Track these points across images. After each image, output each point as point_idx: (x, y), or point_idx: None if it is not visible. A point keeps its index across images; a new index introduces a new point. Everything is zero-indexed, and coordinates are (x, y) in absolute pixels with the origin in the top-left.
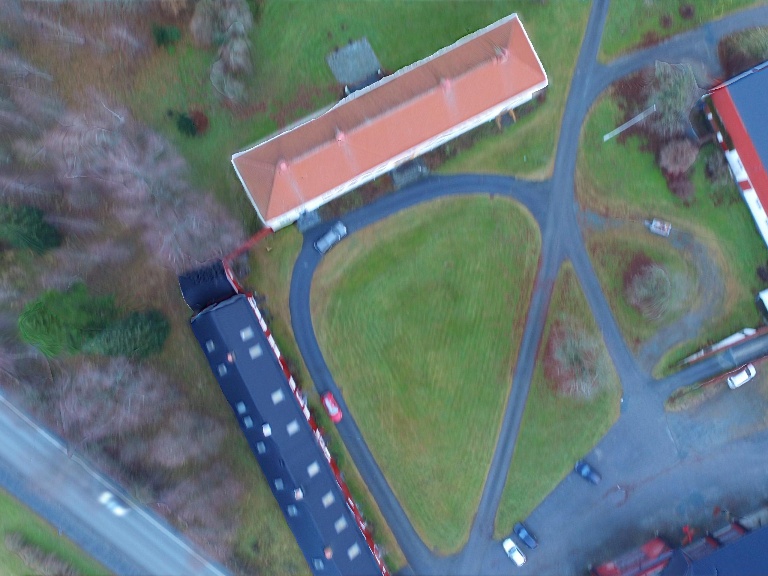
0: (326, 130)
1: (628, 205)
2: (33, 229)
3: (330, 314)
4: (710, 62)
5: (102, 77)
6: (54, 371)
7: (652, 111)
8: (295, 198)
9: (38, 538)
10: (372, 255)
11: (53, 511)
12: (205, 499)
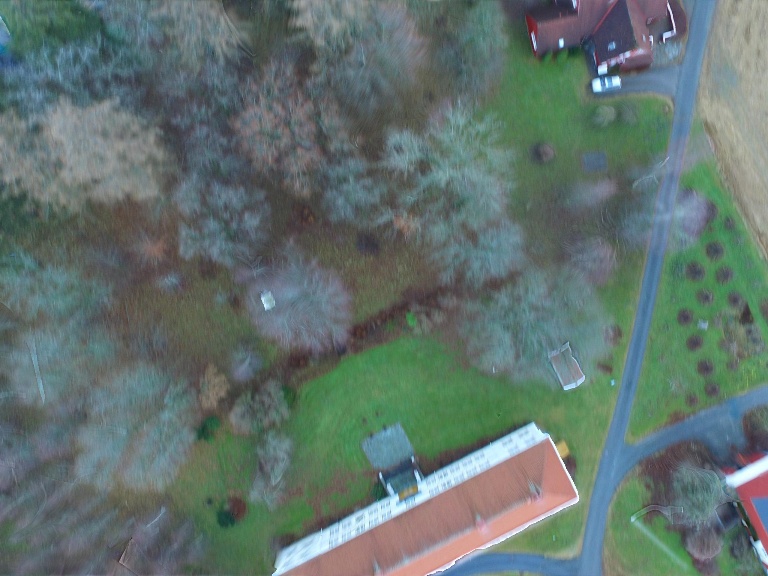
0: (365, 562)
1: None
2: None
3: None
4: (735, 435)
5: (144, 466)
6: None
7: (679, 511)
8: None
9: None
10: None
11: None
12: None
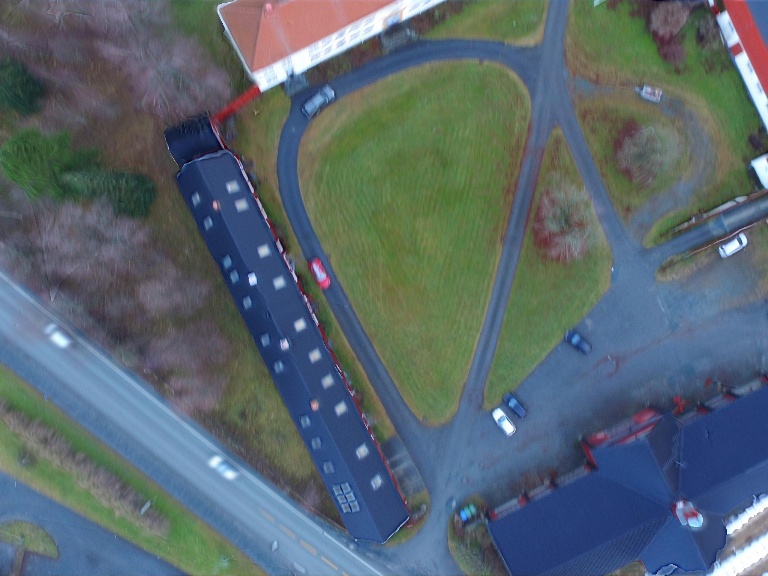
0: None
1: (618, 71)
2: (17, 82)
3: (318, 180)
4: None
5: None
6: (37, 213)
7: None
8: (281, 48)
9: (23, 404)
10: (360, 120)
11: (38, 377)
12: (192, 366)
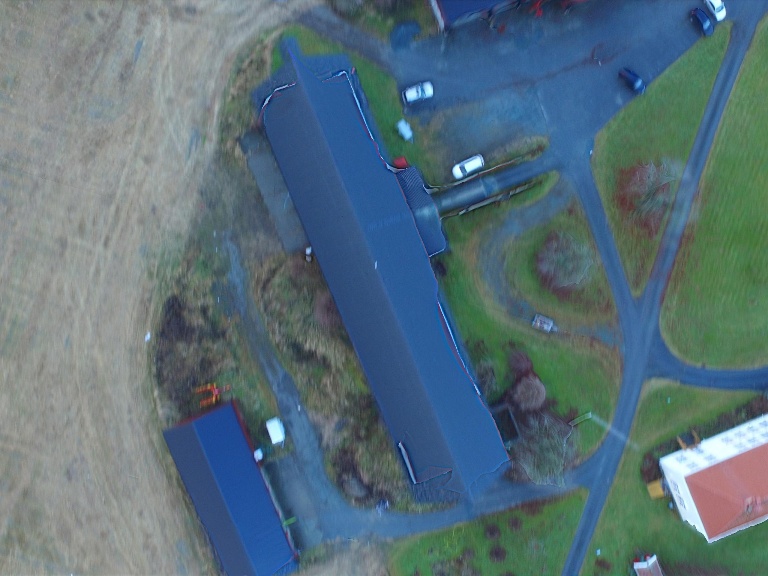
0: None
1: (572, 348)
2: None
3: None
4: None
5: None
6: None
7: None
8: None
9: None
10: None
11: None
12: None
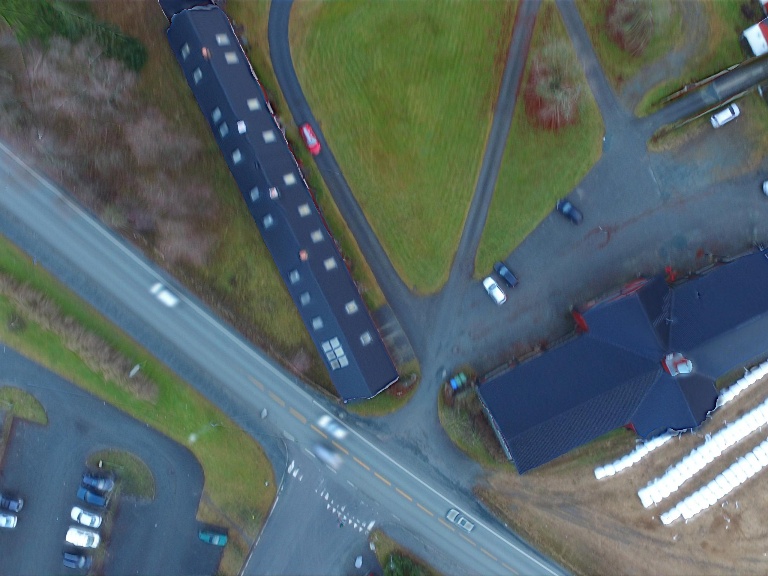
0: None
1: None
2: None
3: (309, 45)
4: None
5: None
6: (26, 54)
7: None
8: None
9: (13, 267)
10: None
11: (28, 240)
12: (182, 232)
